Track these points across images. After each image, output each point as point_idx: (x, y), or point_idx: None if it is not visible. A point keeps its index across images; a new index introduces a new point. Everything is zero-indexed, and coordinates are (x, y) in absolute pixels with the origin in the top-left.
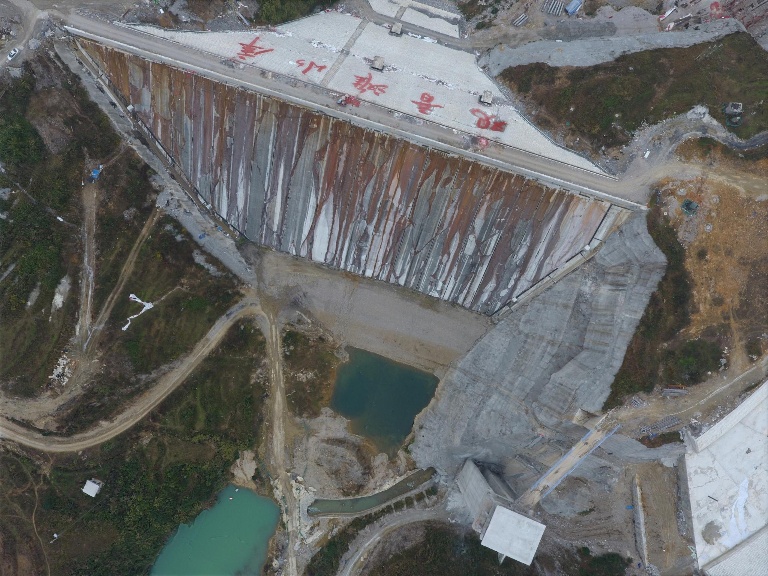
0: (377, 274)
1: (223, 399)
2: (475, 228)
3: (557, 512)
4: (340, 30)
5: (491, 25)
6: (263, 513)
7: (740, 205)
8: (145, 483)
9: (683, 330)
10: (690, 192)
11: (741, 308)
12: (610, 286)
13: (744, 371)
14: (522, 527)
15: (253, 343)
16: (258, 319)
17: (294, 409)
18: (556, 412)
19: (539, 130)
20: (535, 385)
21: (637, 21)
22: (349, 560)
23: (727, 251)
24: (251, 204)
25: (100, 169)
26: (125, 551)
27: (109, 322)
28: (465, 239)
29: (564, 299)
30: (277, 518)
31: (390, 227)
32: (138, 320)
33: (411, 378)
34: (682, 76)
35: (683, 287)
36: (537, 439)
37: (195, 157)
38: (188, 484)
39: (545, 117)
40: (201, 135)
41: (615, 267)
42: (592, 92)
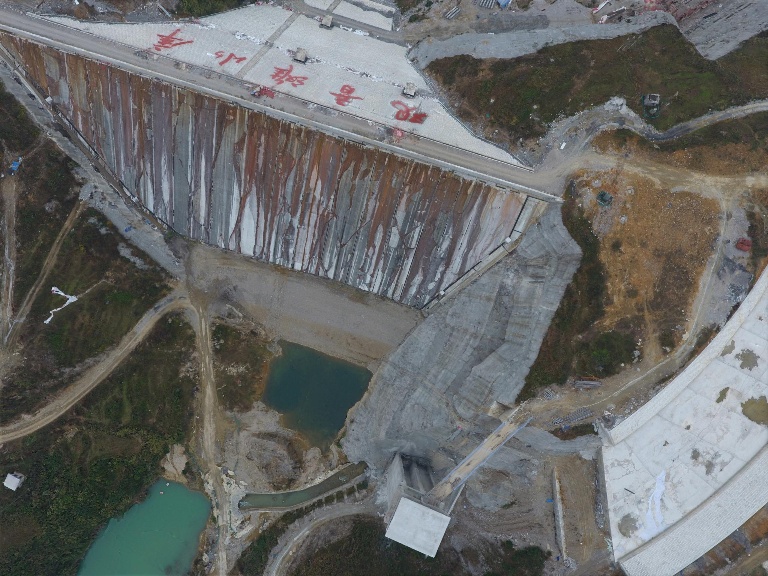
0: (306, 267)
1: (151, 393)
2: (397, 220)
3: (482, 505)
4: (267, 22)
5: (424, 18)
6: (194, 507)
7: (655, 196)
8: (69, 477)
9: (597, 322)
10: (605, 183)
11: (655, 300)
12: (530, 278)
13: (658, 363)
14: (426, 519)
15: (182, 337)
16: (187, 313)
17: (225, 403)
18: (473, 405)
19: (460, 122)
20: (456, 378)
21: (570, 14)
22: (278, 554)
23: (642, 243)
24: (176, 197)
25: (20, 161)
26: (48, 545)
27: (30, 315)
28: (388, 232)
29: (487, 292)
30: (208, 512)
31: (314, 220)
32: (61, 313)
33: (345, 372)
34: (602, 68)
35: (597, 279)
36: (456, 432)
37: (117, 149)
38: (116, 478)
39: (467, 109)
40: (121, 127)
41: (536, 259)
42: (512, 84)
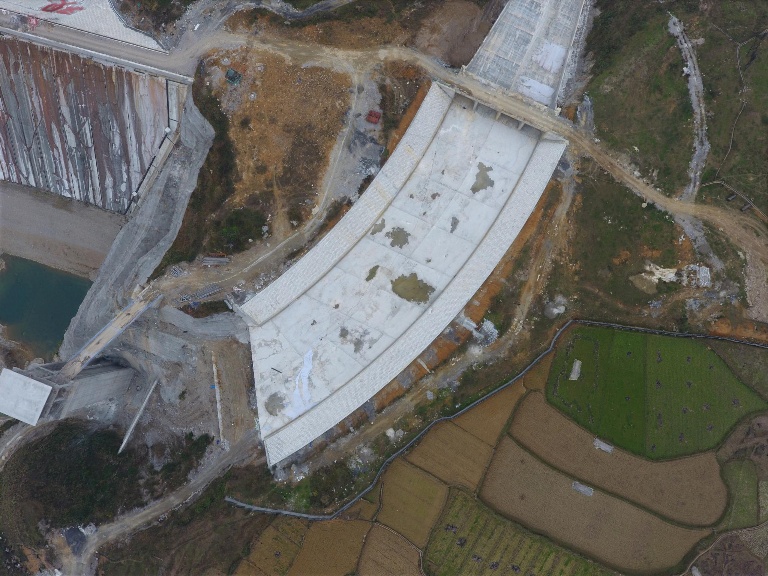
0: (8, 176)
1: None
2: (65, 117)
3: (168, 400)
4: None
5: None
6: None
7: (285, 72)
8: None
9: (228, 199)
10: (234, 61)
11: (285, 175)
12: (188, 167)
13: (286, 237)
14: (28, 389)
15: None
16: None
17: None
18: None
19: (118, 14)
20: (124, 270)
21: None
22: None
23: (271, 119)
24: None
25: None
26: None
27: None
28: (62, 130)
29: (159, 185)
30: None
31: None
32: None
33: (70, 284)
34: None
35: (227, 156)
36: None
37: None
38: None
39: (126, 2)
40: None
41: None
42: None
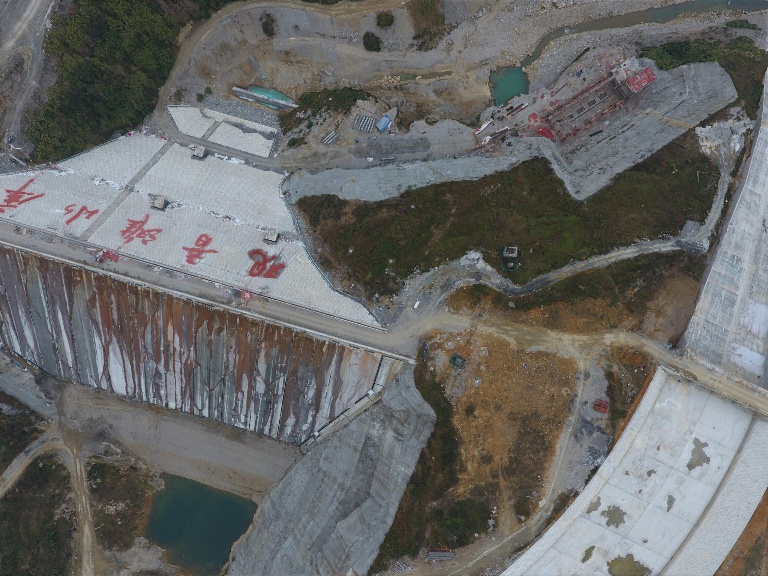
0: (180, 406)
1: (23, 539)
2: (260, 371)
3: None
4: (134, 159)
5: (302, 143)
6: None
7: (510, 358)
8: None
9: (451, 489)
10: (458, 345)
11: (510, 466)
12: (393, 433)
13: (513, 532)
14: None
15: (55, 479)
16: (61, 454)
17: (103, 542)
18: (331, 569)
19: (320, 271)
20: (321, 533)
21: (452, 136)
22: None
23: (496, 406)
24: (41, 343)
25: None
26: None
27: None
28: (253, 380)
29: (355, 441)
30: None
31: (179, 367)
32: None
33: (230, 503)
34: (463, 215)
35: (451, 445)
36: None
37: None
38: None
39: (327, 257)
40: None
41: (399, 412)
42: (371, 233)
